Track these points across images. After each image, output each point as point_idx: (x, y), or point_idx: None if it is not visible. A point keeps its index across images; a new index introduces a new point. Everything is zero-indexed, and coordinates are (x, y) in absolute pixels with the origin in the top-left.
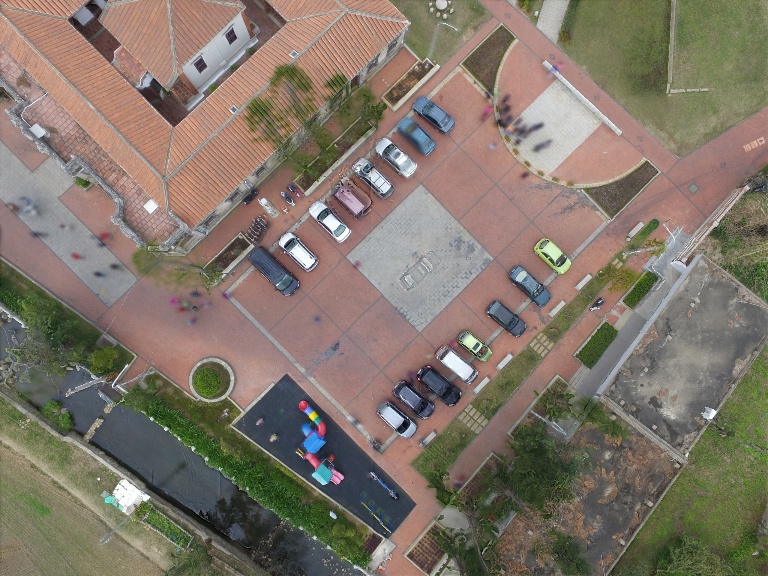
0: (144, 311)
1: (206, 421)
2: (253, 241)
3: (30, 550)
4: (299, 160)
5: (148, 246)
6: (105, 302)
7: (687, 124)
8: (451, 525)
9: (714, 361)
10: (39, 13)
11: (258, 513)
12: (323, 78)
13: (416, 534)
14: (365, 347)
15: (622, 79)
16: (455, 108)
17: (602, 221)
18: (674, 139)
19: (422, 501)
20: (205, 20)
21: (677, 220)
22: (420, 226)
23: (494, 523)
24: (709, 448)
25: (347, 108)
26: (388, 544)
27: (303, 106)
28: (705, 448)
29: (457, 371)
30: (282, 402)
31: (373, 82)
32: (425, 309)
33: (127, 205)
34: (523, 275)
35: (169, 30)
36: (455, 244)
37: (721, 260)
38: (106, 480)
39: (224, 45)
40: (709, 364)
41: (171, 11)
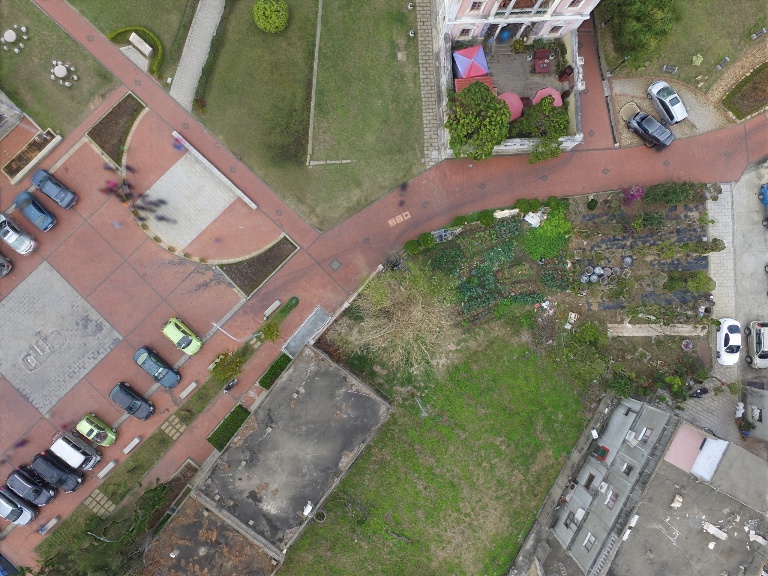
0: None
1: None
2: None
3: None
4: None
5: None
6: None
7: (329, 197)
8: None
9: (319, 453)
10: None
11: None
12: None
13: None
14: None
15: (261, 149)
16: (82, 180)
17: (239, 299)
18: (316, 213)
19: None
20: None
21: (318, 298)
22: (44, 304)
23: None
24: (346, 534)
25: None
26: None
27: None
28: (341, 534)
29: (66, 459)
30: None
31: None
32: (49, 391)
33: None
34: (143, 358)
35: None
36: (82, 323)
37: (358, 341)
38: None
39: None
40: (313, 456)
41: None
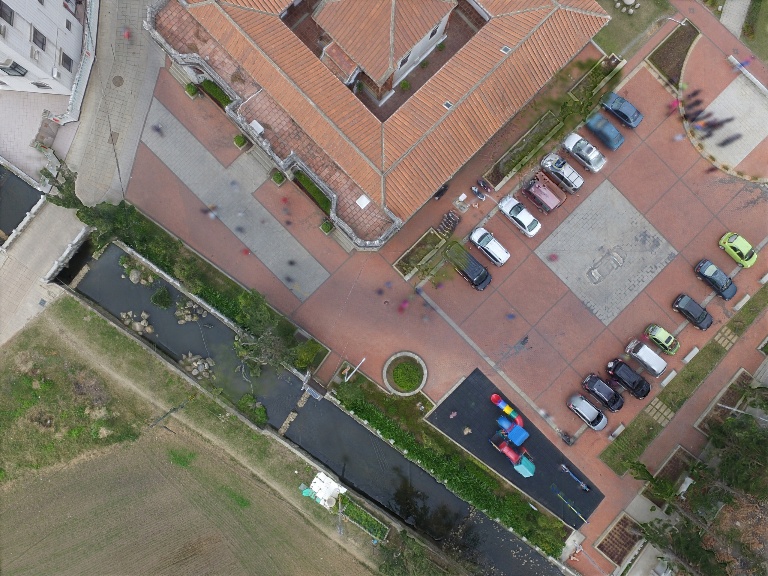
0: (337, 306)
1: (400, 414)
2: (445, 236)
3: (231, 542)
4: (487, 155)
5: (365, 241)
6: (299, 297)
7: None
8: (640, 517)
9: None
10: (254, 10)
11: (425, 506)
12: (530, 73)
13: (605, 526)
14: (553, 341)
15: None
16: (640, 103)
17: None
18: None
19: (610, 493)
20: (422, 16)
21: None
22: (606, 221)
23: (702, 514)
24: None
25: (534, 103)
26: (578, 536)
27: (510, 101)
28: None
29: (651, 364)
30: (473, 396)
31: (559, 77)
32: (612, 303)
33: (339, 200)
34: (712, 269)
35: (390, 26)
36: (640, 238)
37: None
38: (303, 473)
39: (426, 41)
40: None
41: (395, 7)
